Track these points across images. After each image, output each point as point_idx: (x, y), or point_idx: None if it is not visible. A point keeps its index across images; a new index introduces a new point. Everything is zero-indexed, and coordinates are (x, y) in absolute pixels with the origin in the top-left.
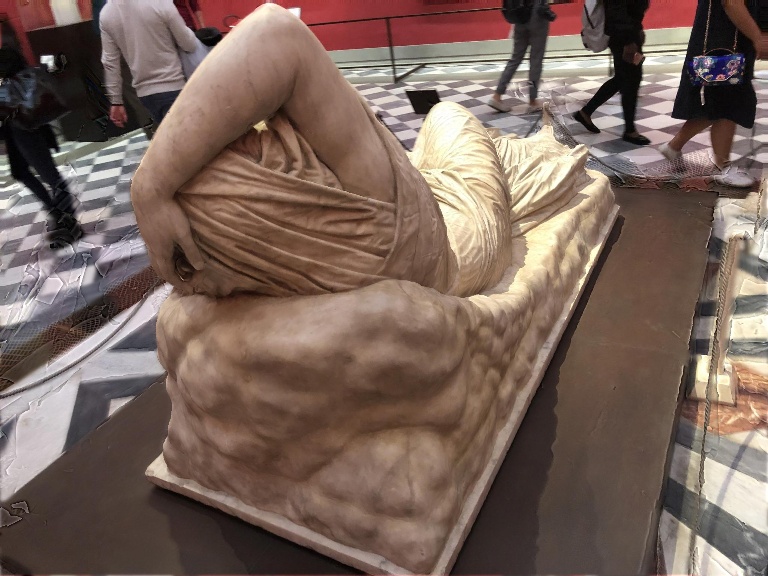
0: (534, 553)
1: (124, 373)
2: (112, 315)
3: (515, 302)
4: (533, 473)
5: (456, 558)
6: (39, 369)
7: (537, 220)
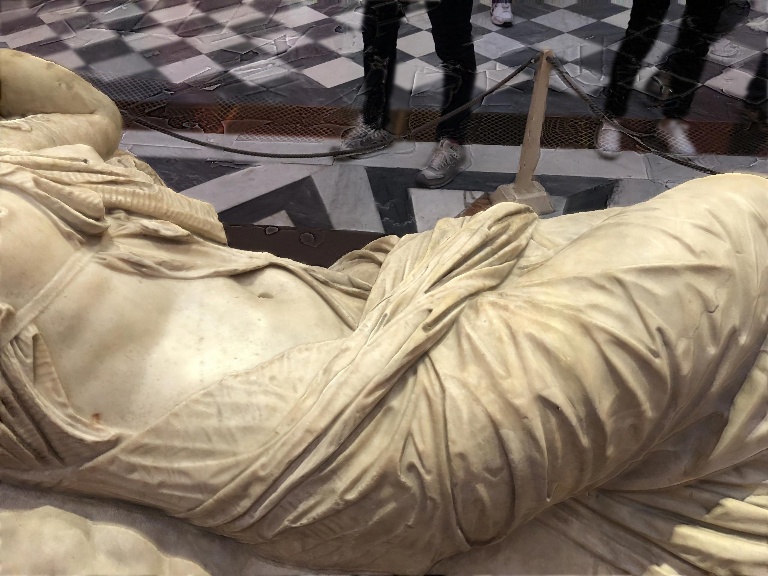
0: None
1: (326, 198)
2: (425, 139)
3: None
4: None
5: None
6: (234, 137)
7: None
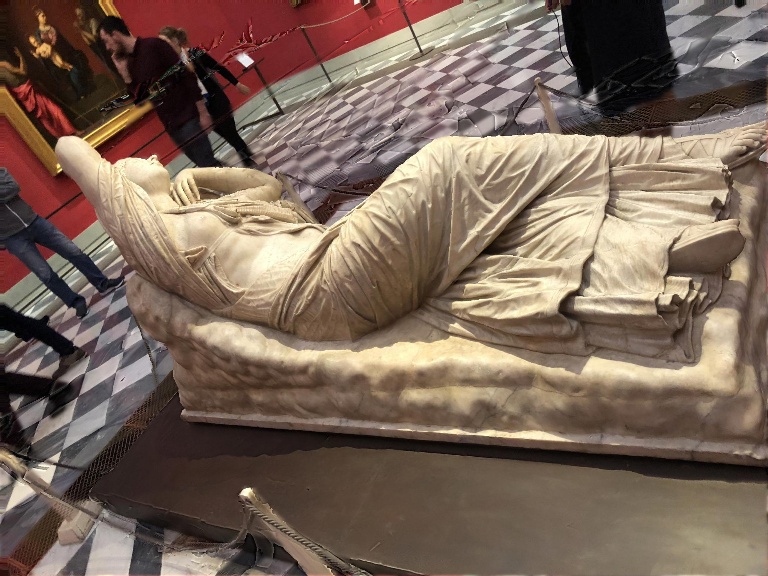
0: (197, 458)
1: None
2: None
3: (254, 355)
4: (248, 448)
5: (201, 422)
6: None
7: (478, 335)
